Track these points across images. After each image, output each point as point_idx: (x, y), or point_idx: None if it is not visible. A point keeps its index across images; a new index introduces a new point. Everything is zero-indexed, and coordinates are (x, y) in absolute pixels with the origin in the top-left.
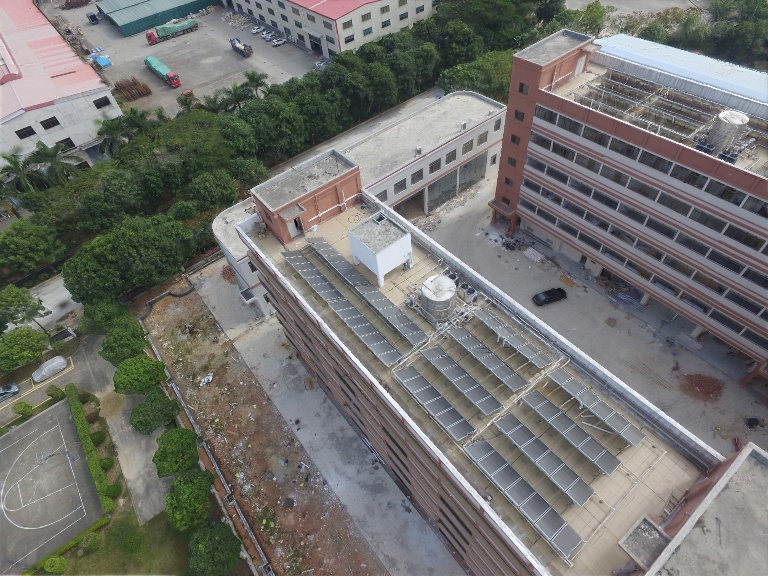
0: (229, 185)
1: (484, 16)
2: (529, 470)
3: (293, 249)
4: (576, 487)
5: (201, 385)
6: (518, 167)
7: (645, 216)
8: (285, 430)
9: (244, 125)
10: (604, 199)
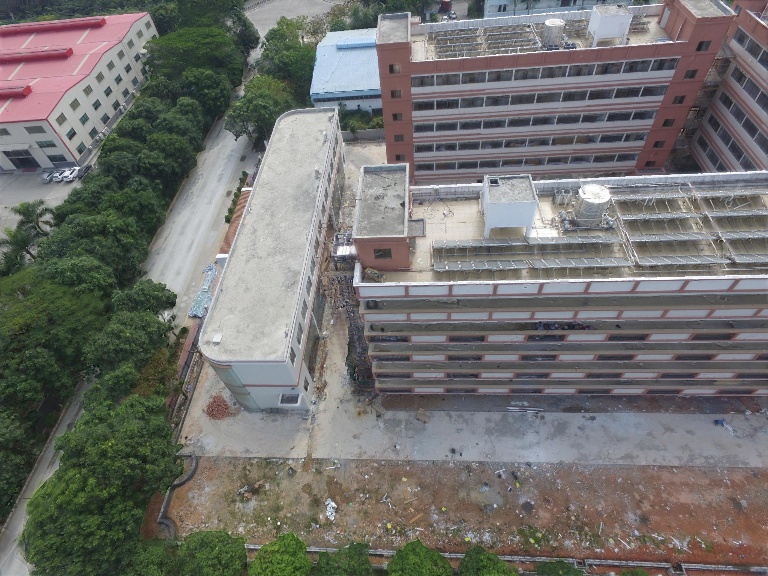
0: (148, 320)
1: (208, 58)
2: (759, 249)
3: (424, 266)
4: None
5: (332, 519)
6: (406, 139)
7: (529, 118)
8: (452, 467)
9: (82, 259)
10: (493, 124)
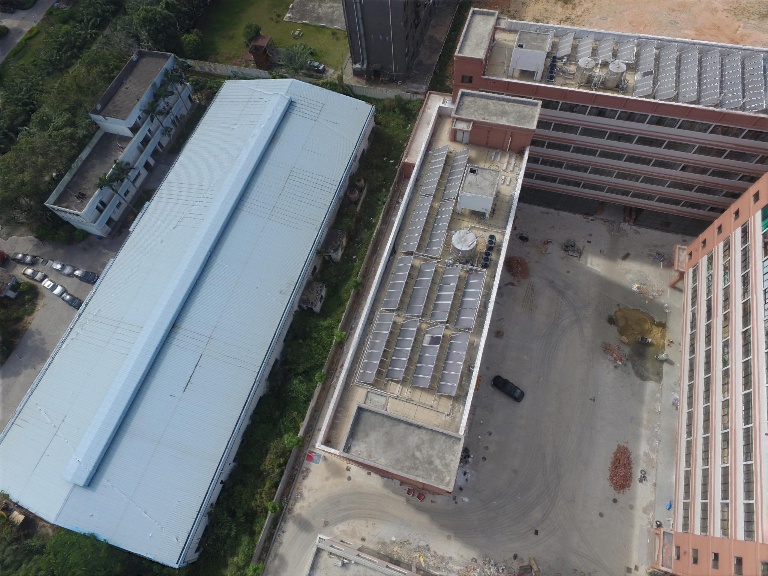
0: None
1: None
2: None
3: None
4: None
5: None
6: None
7: None
8: None
9: None
10: None
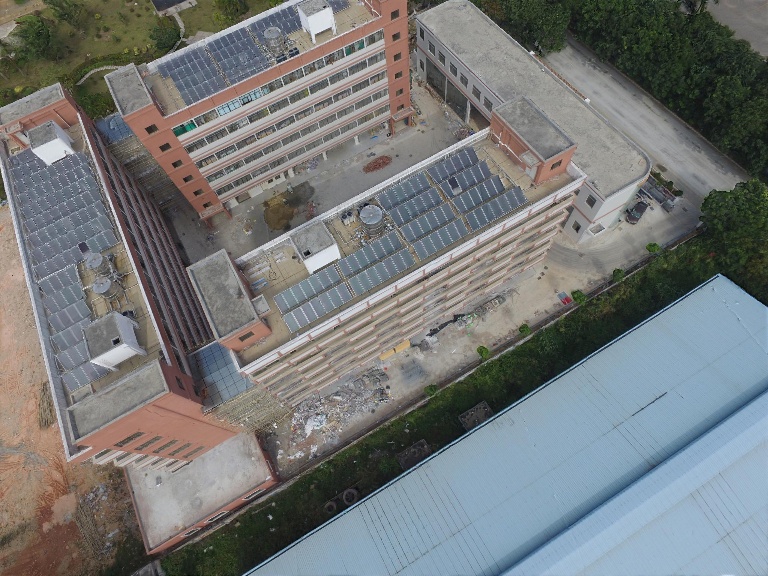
0: (522, 8)
1: None
2: None
3: None
4: (177, 77)
5: None
6: None
7: None
8: None
9: (613, 1)
10: None
